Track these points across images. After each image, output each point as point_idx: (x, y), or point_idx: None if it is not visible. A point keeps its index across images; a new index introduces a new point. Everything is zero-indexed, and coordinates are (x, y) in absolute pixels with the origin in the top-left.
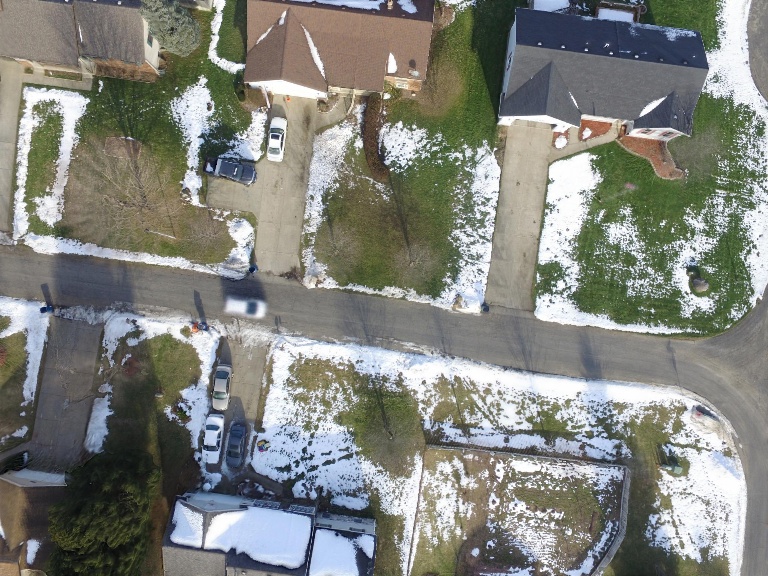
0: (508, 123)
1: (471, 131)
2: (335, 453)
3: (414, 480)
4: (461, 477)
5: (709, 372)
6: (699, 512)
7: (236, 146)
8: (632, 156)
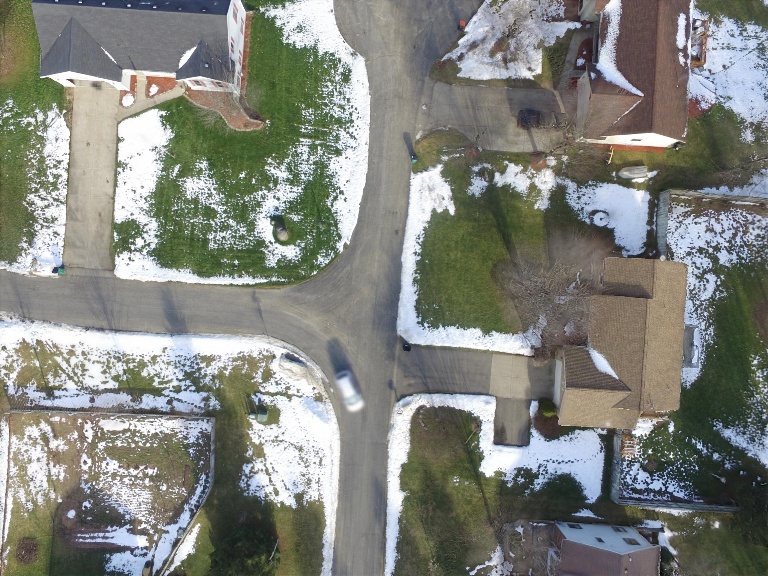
0: (69, 84)
1: (42, 95)
2: None
3: (2, 446)
4: (49, 440)
5: (296, 319)
6: (292, 458)
7: None
8: (202, 110)
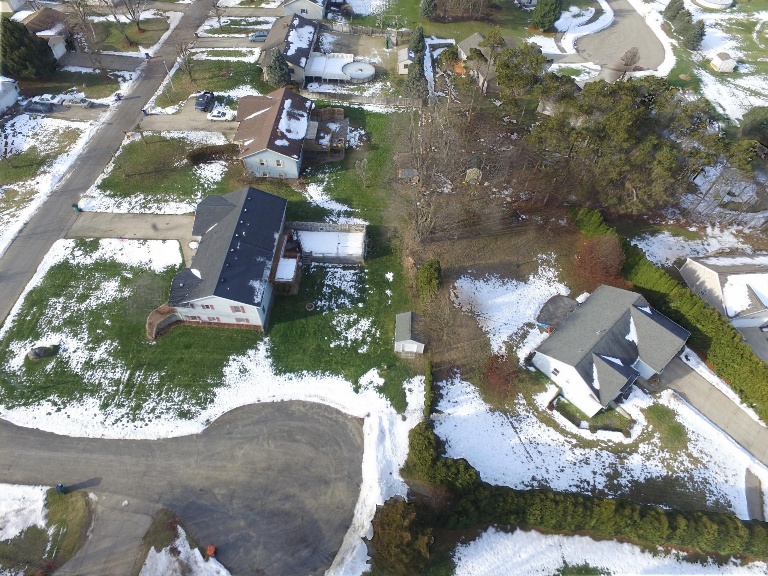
0: None
1: None
2: (11, 147)
3: None
4: None
5: None
6: None
7: (221, 106)
8: None
